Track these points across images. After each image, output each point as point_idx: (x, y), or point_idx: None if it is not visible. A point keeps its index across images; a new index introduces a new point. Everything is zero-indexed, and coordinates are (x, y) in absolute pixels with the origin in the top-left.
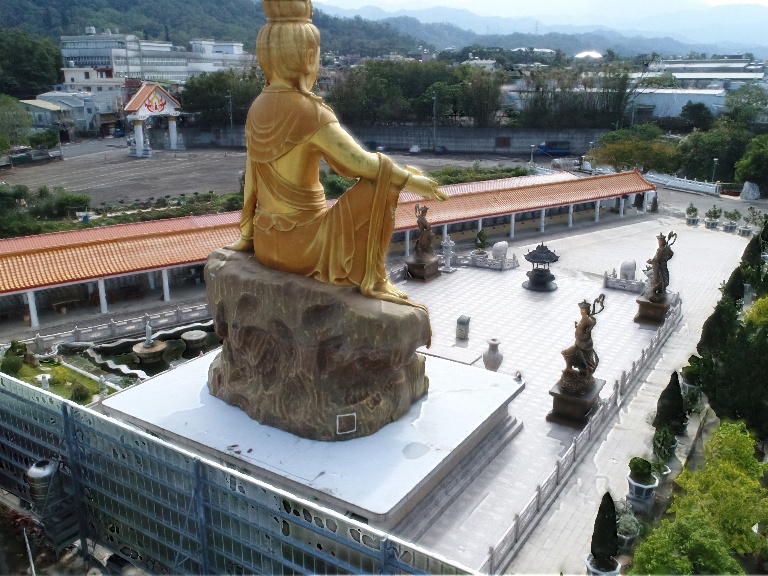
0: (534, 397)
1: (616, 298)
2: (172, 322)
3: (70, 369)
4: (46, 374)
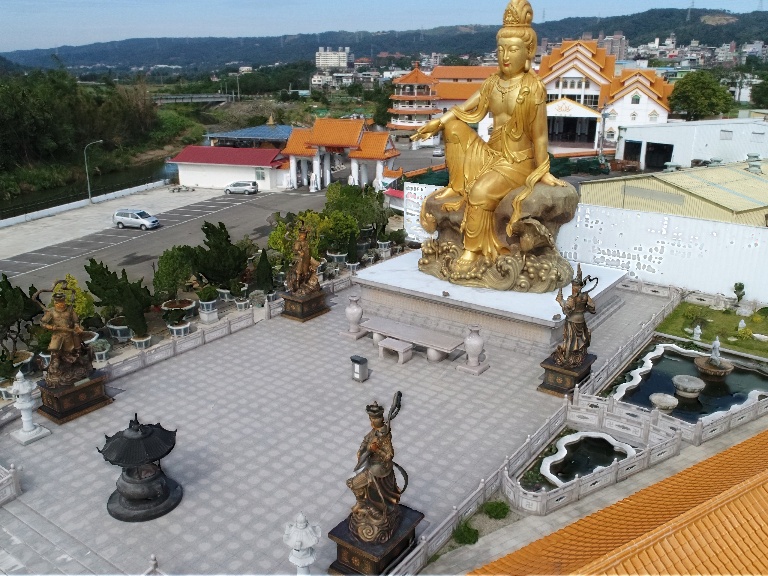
0: (327, 324)
1: (55, 455)
2: (760, 414)
3: (767, 358)
4: (763, 337)
